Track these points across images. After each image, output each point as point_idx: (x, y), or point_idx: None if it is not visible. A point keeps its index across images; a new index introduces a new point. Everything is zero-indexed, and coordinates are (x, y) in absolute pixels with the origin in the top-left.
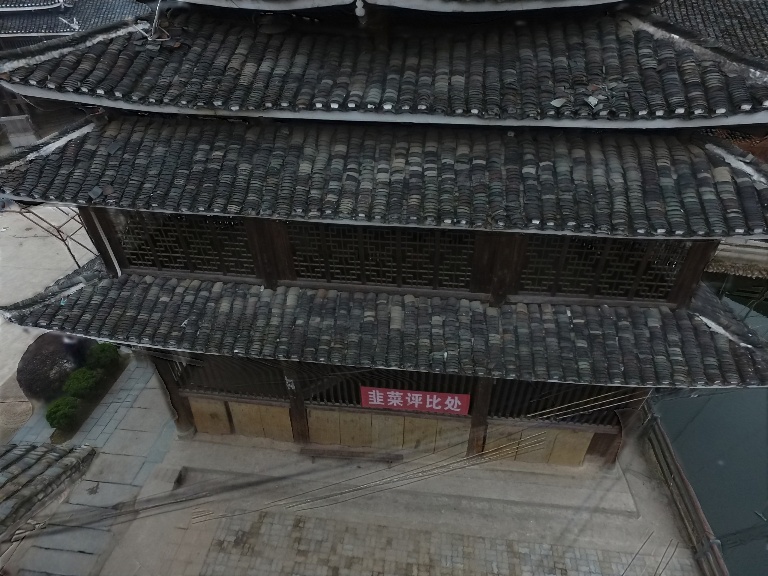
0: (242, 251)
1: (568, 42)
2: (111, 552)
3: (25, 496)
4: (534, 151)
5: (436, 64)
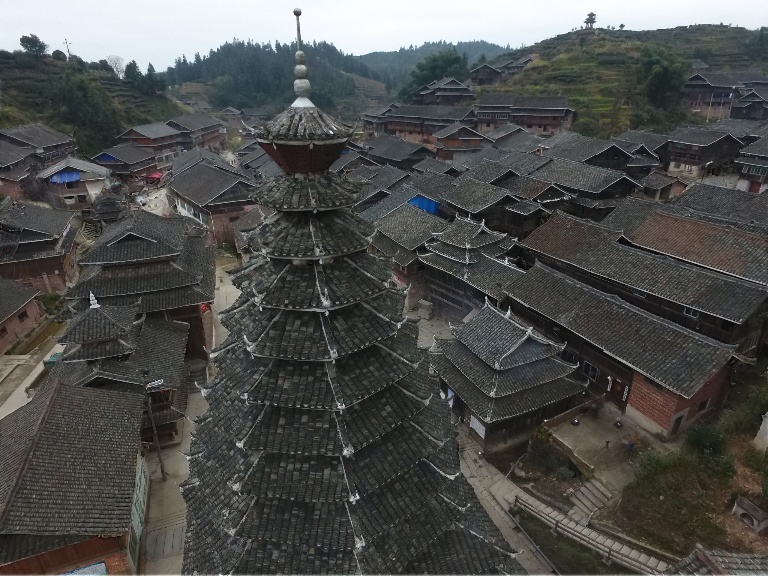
0: None
1: None
2: (173, 556)
3: (105, 530)
4: None
5: None
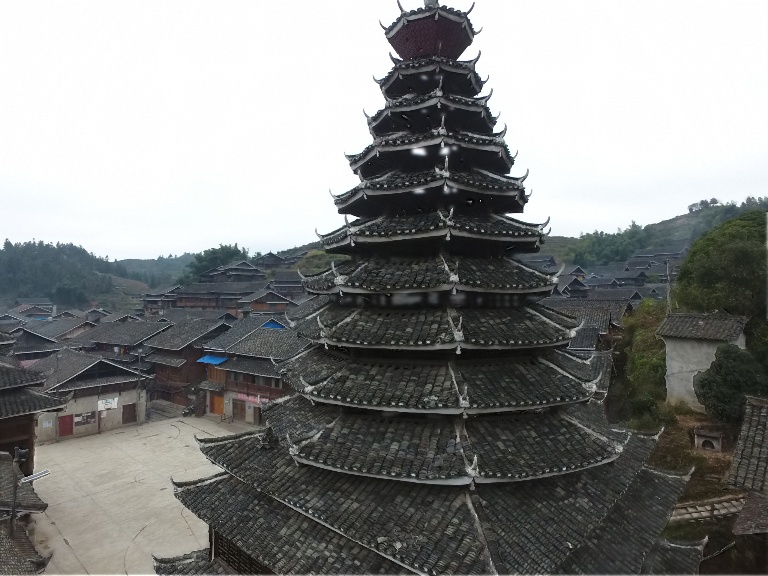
0: (259, 571)
1: (425, 498)
2: None
3: None
4: (388, 567)
5: (354, 491)
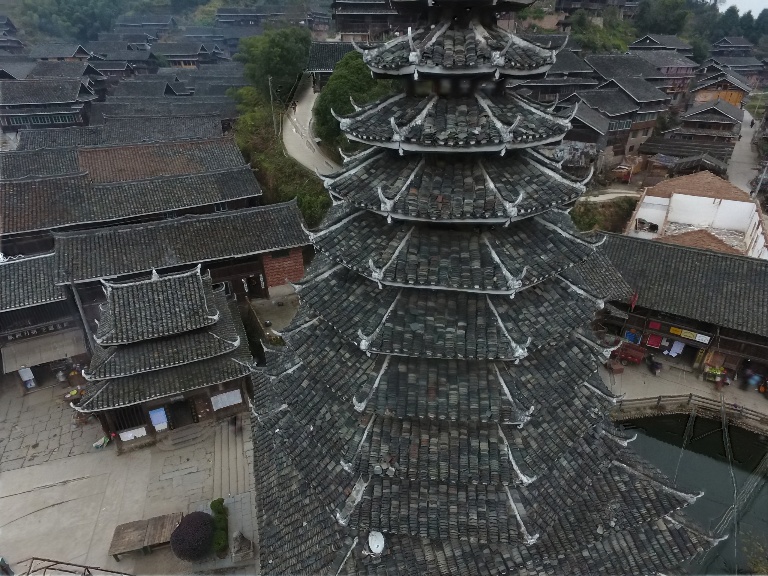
0: None
1: None
2: None
3: None
4: None
5: None
